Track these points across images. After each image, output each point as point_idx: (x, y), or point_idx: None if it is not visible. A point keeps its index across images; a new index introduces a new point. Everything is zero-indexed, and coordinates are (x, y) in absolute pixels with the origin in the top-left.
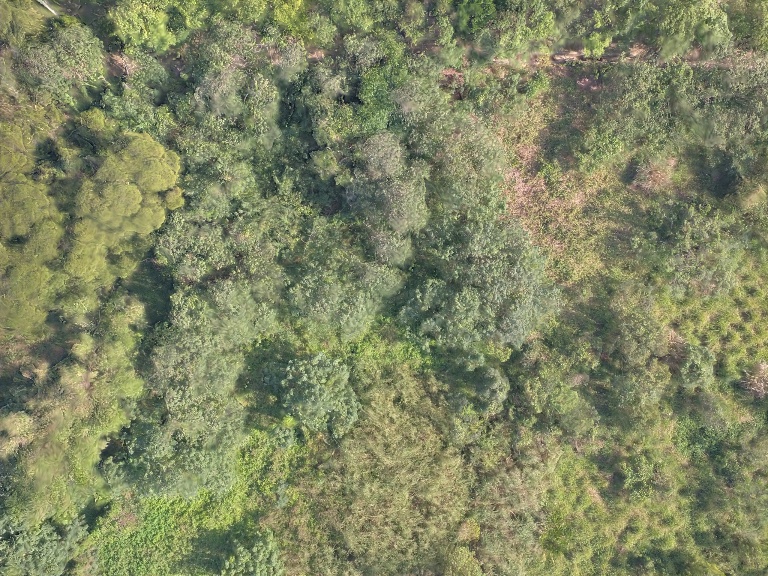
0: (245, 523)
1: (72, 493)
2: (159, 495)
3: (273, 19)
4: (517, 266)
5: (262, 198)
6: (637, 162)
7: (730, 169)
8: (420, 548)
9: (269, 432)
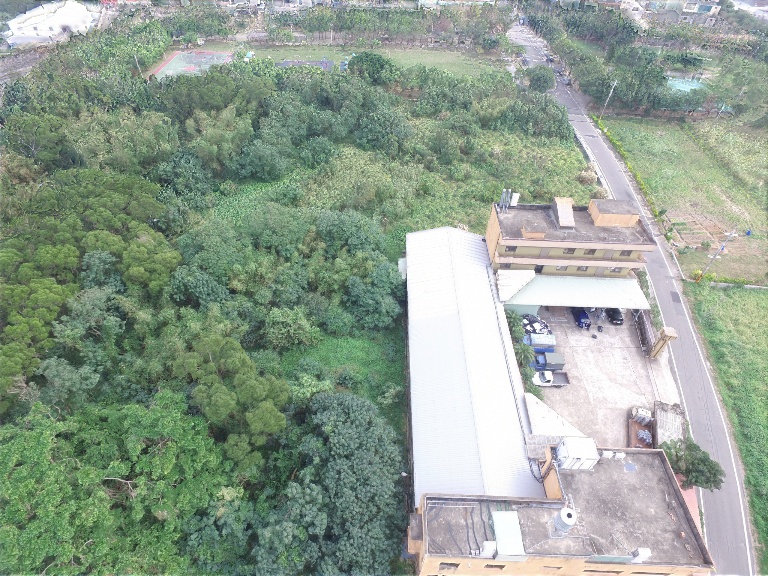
0: None
1: None
2: (248, 186)
3: None
4: None
5: None
6: None
7: (468, 109)
8: None
9: None
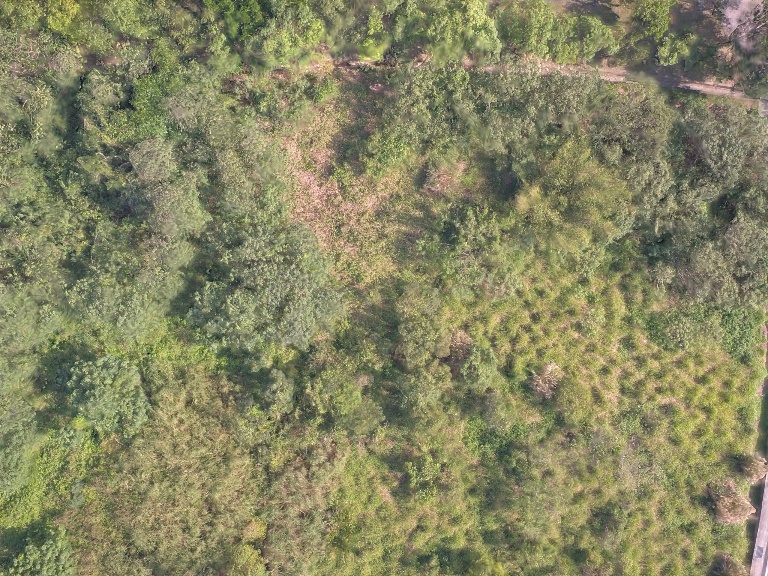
0: (44, 521)
1: None
2: None
3: (47, 27)
4: (290, 269)
5: (47, 202)
6: (427, 166)
7: (512, 173)
8: (209, 546)
9: (56, 432)
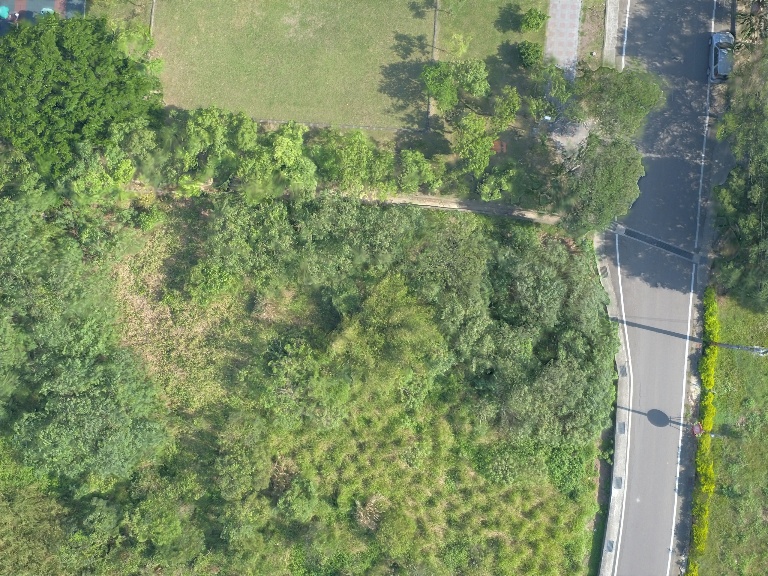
0: None
1: None
2: None
3: None
4: (102, 404)
5: None
6: (256, 293)
7: None
8: None
9: None
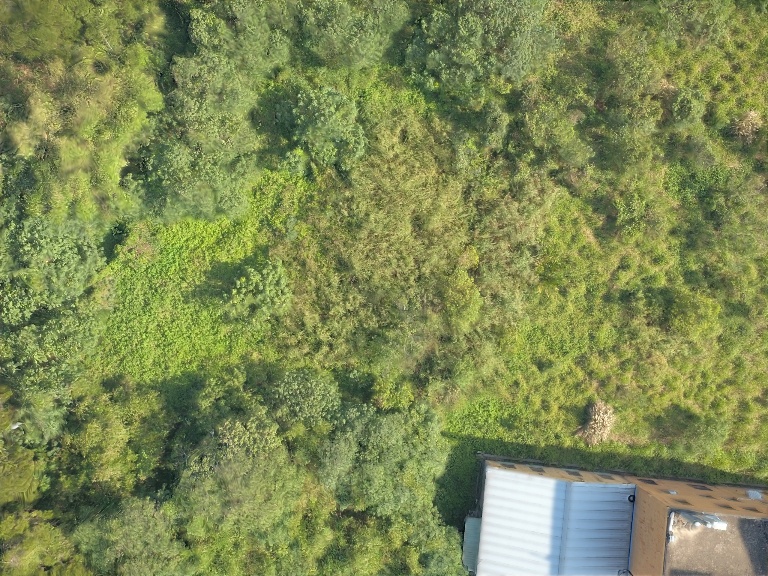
0: (255, 258)
1: (92, 219)
2: (174, 232)
3: None
4: None
5: None
6: None
7: None
8: (421, 276)
9: (280, 158)
